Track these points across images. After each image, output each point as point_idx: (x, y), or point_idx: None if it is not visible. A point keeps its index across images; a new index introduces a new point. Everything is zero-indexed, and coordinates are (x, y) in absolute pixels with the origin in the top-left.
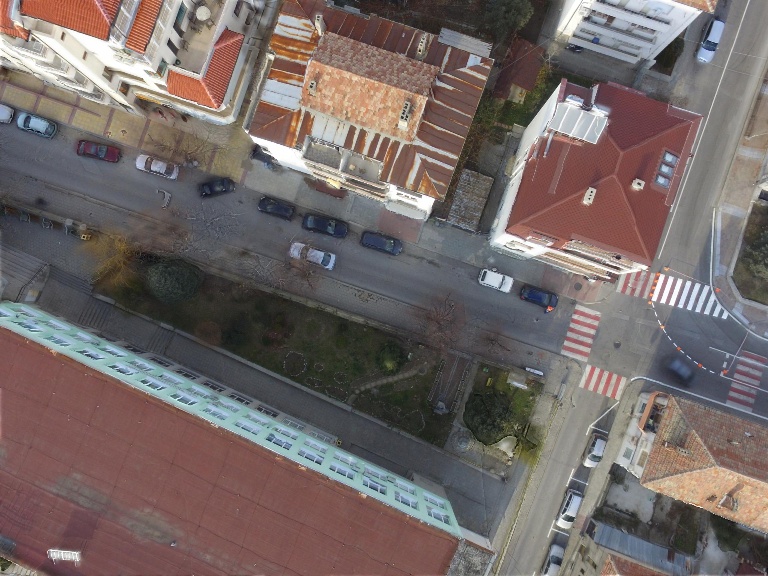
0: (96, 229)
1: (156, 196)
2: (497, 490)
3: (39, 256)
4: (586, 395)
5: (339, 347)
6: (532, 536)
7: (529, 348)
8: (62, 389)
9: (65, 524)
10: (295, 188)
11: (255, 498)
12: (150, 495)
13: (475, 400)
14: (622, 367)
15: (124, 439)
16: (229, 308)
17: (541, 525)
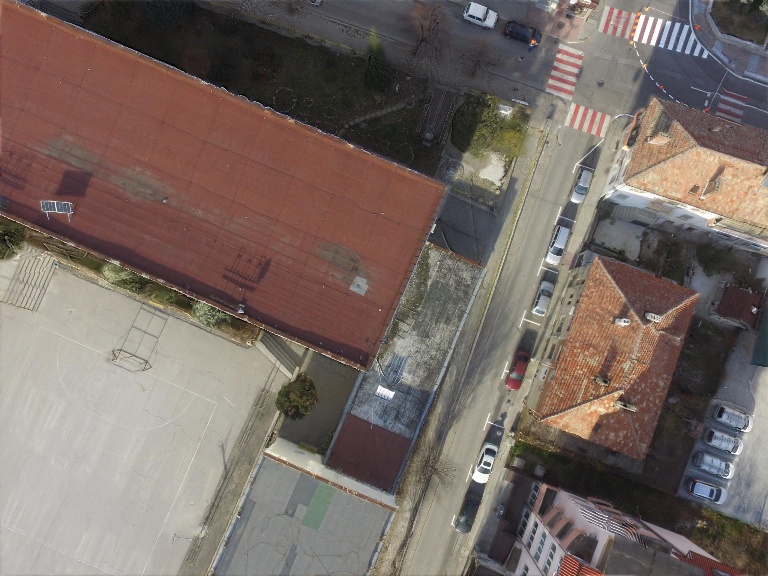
0: None
1: None
2: (486, 222)
3: None
4: (572, 133)
5: (328, 81)
6: (522, 275)
7: (514, 85)
8: (53, 53)
9: (58, 183)
10: None
11: (245, 153)
12: (142, 154)
13: None
14: (606, 105)
15: (115, 100)
16: (219, 44)
17: (531, 263)
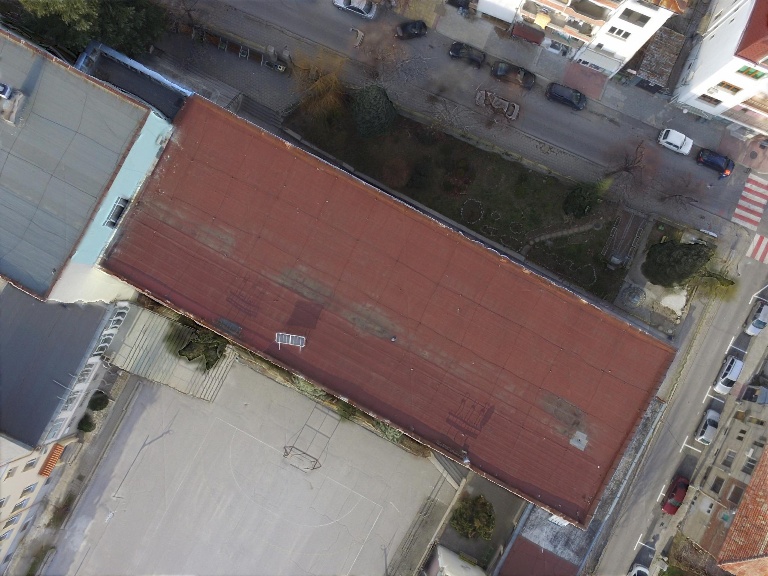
0: (292, 61)
1: (349, 34)
2: None
3: (233, 85)
4: (752, 264)
5: (518, 197)
6: (687, 401)
7: (702, 212)
8: (293, 182)
9: (289, 313)
10: (485, 36)
11: (477, 299)
12: (373, 291)
13: (665, 243)
14: None
15: (351, 235)
16: (412, 151)
17: (697, 390)
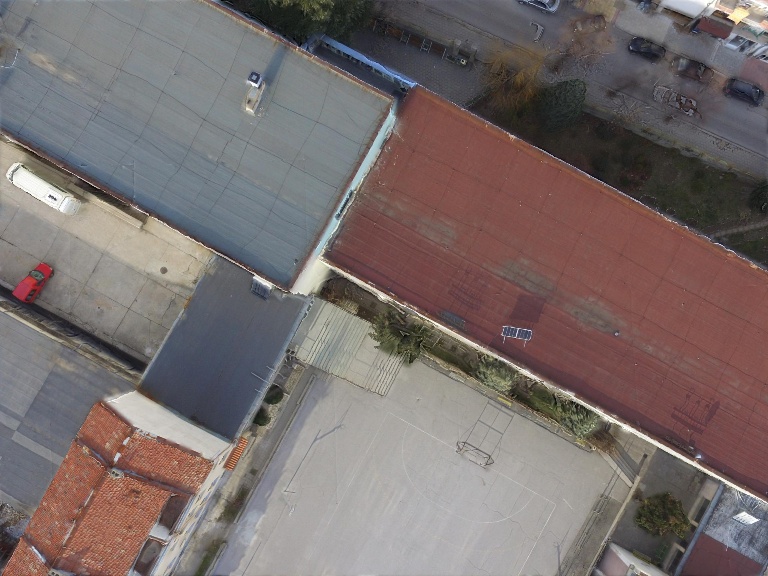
0: None
1: (529, 28)
2: None
3: (414, 78)
4: None
5: (694, 193)
6: None
7: None
8: (515, 175)
9: (512, 306)
10: (664, 31)
11: (701, 294)
12: (596, 285)
13: None
14: None
15: (574, 228)
16: (589, 146)
17: None
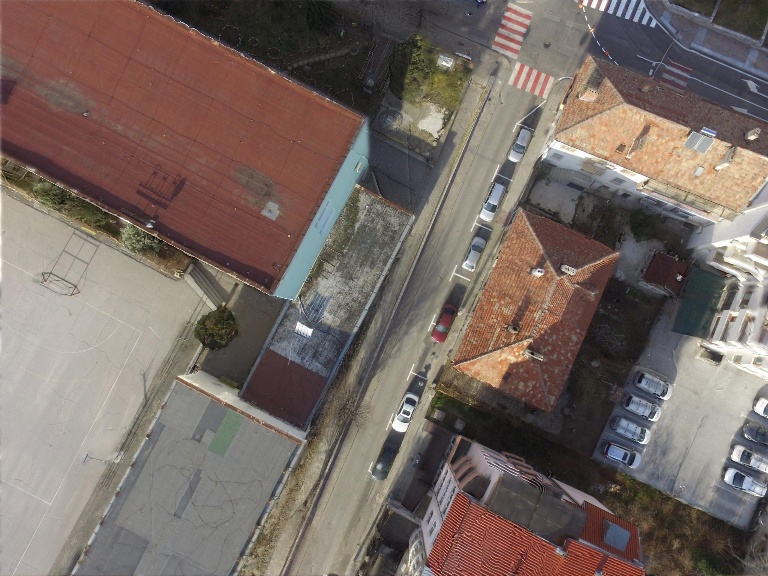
0: None
1: None
2: (422, 173)
3: None
4: (514, 93)
5: (274, 22)
6: (456, 230)
7: (460, 39)
8: None
9: None
10: None
11: (168, 73)
12: (66, 67)
13: None
14: (551, 67)
15: (44, 11)
16: None
17: (465, 219)
